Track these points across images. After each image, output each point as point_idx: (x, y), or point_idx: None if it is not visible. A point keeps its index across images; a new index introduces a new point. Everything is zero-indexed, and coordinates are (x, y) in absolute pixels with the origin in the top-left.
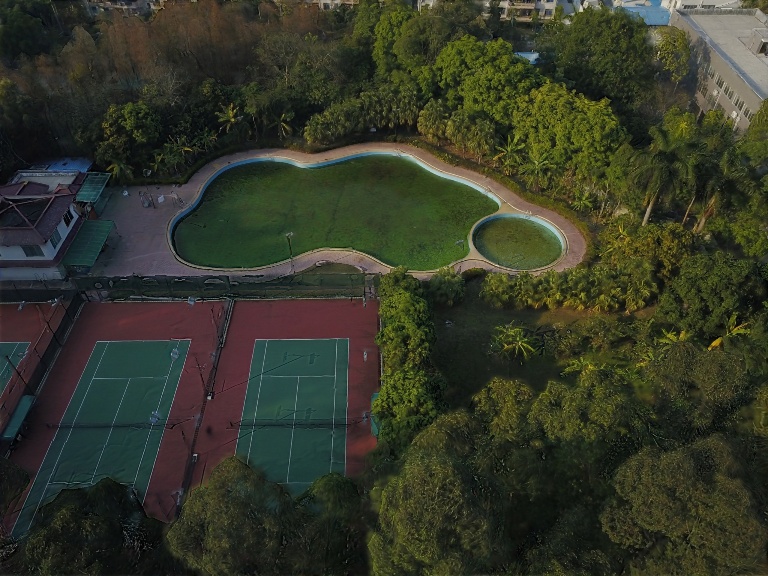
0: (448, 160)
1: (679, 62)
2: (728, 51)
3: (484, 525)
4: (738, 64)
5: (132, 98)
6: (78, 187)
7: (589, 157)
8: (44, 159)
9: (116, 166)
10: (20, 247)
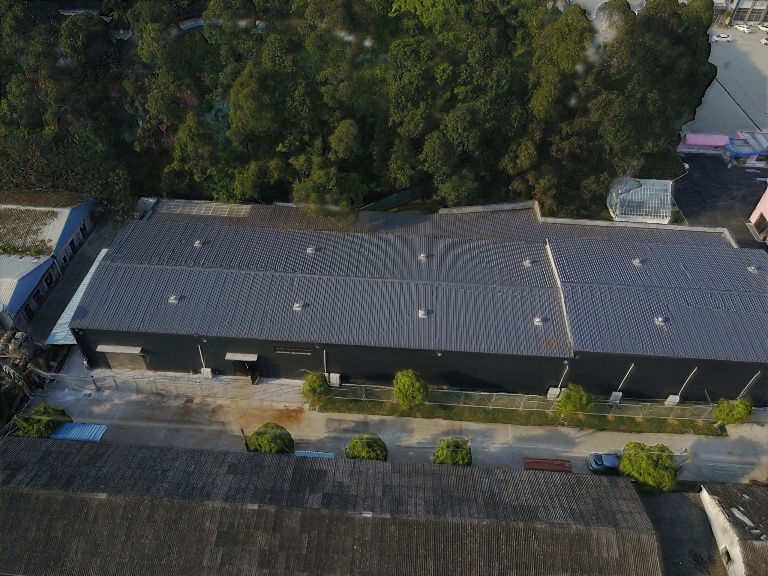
0: None
1: None
2: None
3: None
4: None
5: None
6: None
7: None
8: (66, 8)
9: (116, 13)
10: None
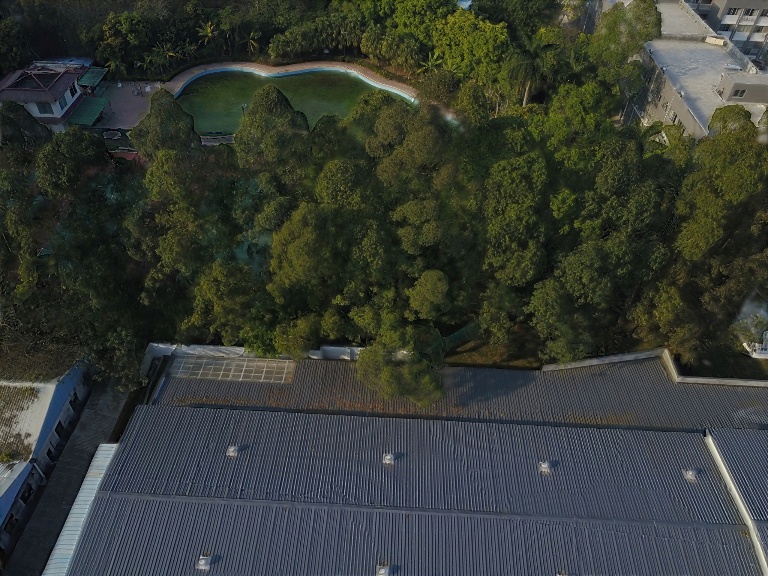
0: (384, 75)
1: (575, 4)
2: None
3: (289, 117)
4: None
5: (128, 11)
6: (82, 71)
7: (487, 67)
8: (54, 57)
9: (113, 63)
10: (35, 105)
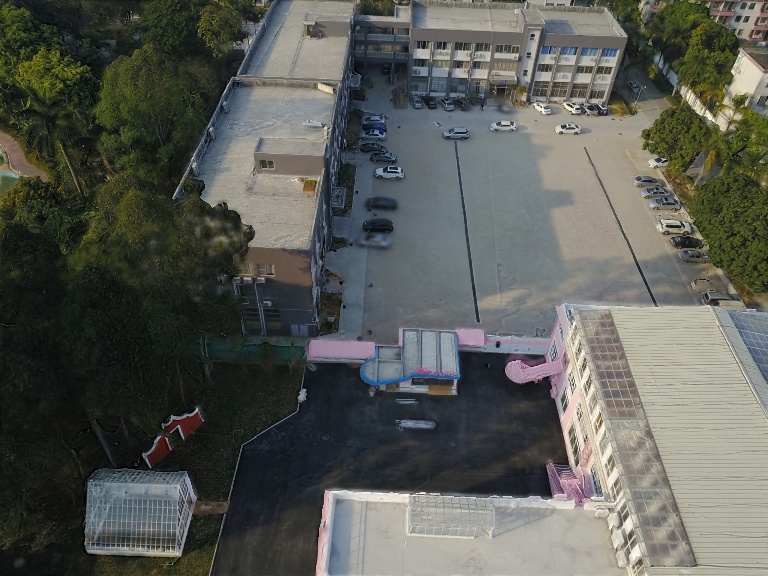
0: None
1: (219, 40)
2: (284, 33)
3: None
4: (276, 44)
5: None
6: None
7: None
8: None
9: None
10: None
